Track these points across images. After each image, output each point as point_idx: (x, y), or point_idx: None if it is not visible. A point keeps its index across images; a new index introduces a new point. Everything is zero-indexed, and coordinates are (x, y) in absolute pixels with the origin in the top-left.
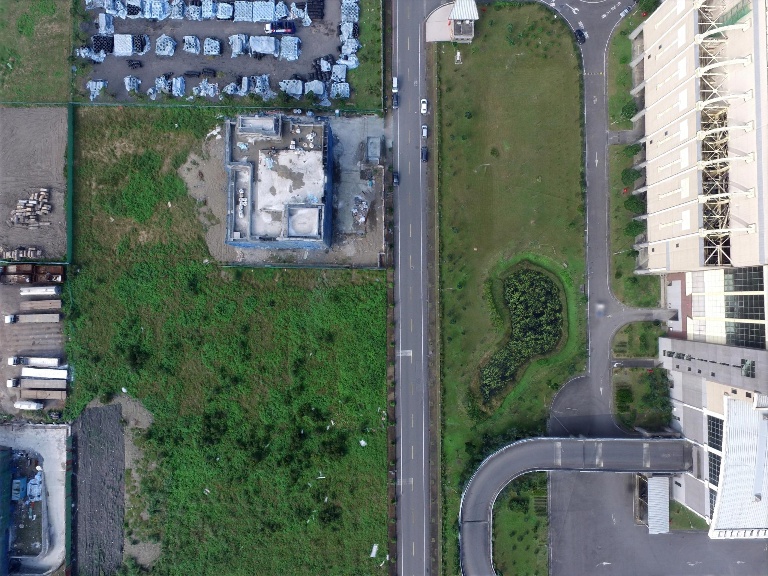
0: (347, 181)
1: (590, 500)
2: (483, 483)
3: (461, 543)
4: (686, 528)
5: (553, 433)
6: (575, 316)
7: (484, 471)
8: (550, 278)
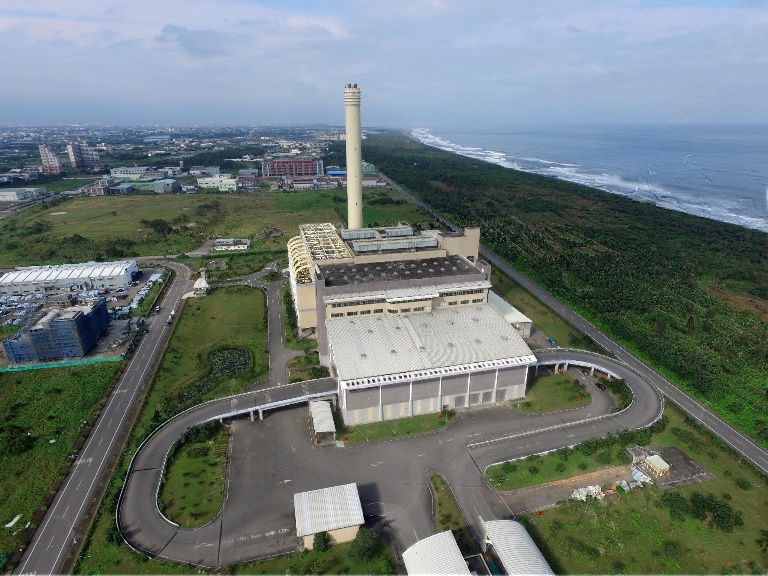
0: (112, 336)
1: (270, 441)
2: (162, 438)
3: (125, 489)
4: (362, 442)
5: None
6: (259, 358)
7: (165, 430)
8: (243, 349)
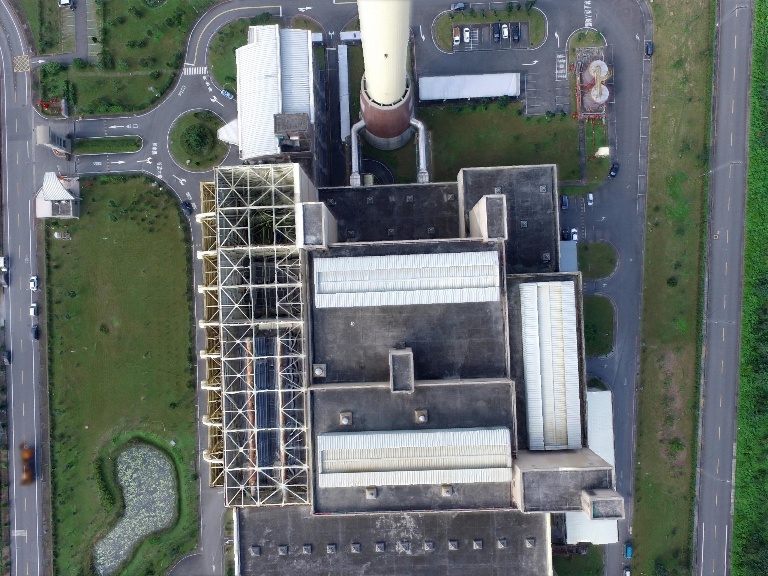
0: None
1: None
2: None
3: None
4: None
5: None
6: (185, 494)
7: None
8: None
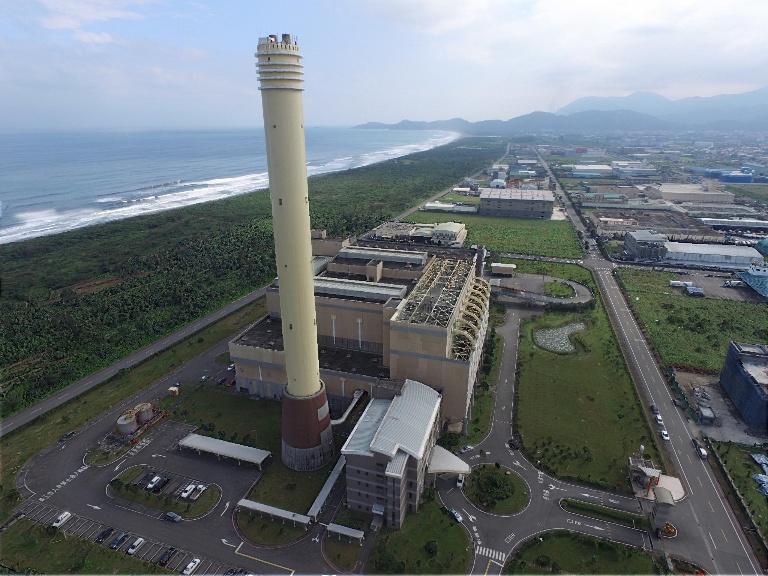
0: None
1: None
2: (583, 300)
3: None
4: None
5: (542, 309)
6: (528, 333)
7: None
8: None
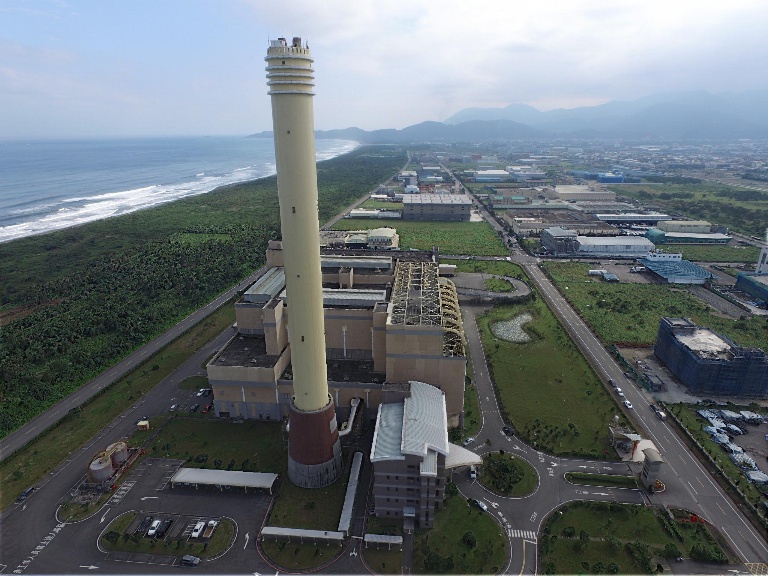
0: None
1: None
2: None
3: None
4: None
5: (490, 304)
6: None
7: None
8: None
